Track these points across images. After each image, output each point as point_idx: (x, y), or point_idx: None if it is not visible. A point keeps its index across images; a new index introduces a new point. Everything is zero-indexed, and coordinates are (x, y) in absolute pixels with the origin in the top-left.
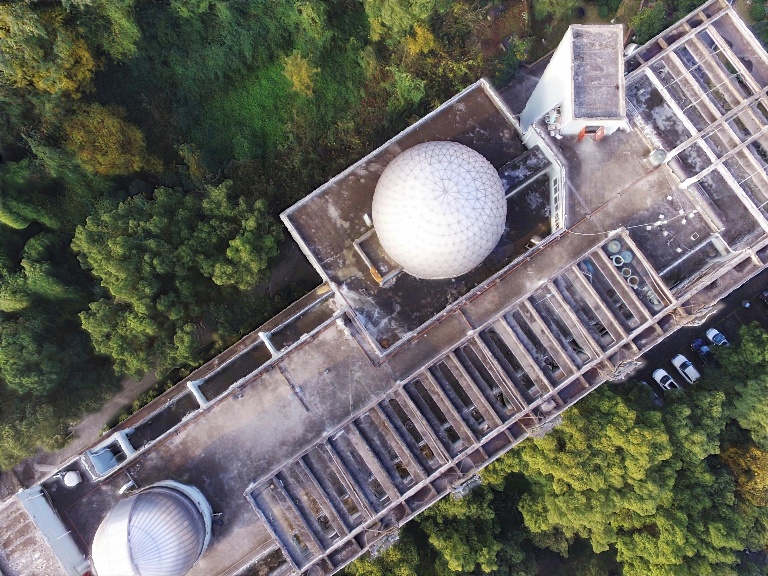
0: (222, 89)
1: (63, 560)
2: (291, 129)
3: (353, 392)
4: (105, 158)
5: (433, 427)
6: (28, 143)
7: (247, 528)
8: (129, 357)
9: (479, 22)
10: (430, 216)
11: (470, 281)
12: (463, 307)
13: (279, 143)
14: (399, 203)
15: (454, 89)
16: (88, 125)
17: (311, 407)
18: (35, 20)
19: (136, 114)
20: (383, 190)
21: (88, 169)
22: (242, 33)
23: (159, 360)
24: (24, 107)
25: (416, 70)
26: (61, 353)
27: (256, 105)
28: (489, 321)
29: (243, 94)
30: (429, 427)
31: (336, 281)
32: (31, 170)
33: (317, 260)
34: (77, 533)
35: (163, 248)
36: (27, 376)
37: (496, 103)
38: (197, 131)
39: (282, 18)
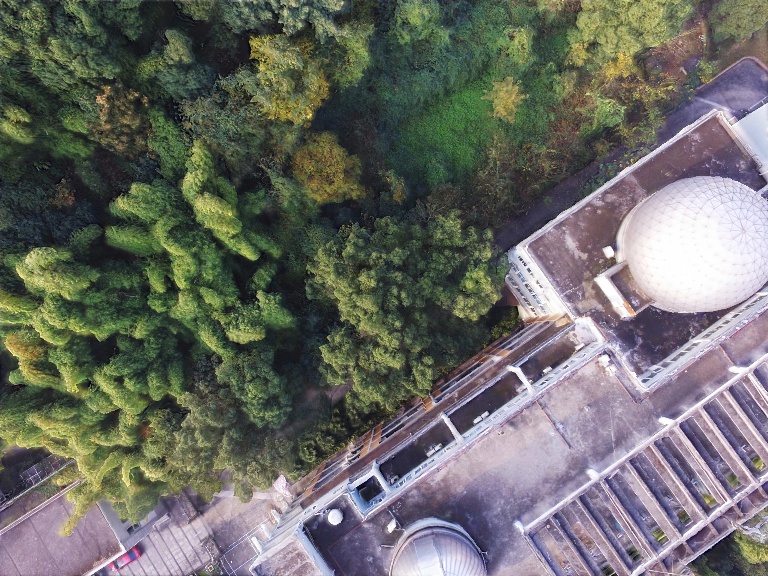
0: (418, 114)
1: None
2: (494, 155)
3: (615, 429)
4: (332, 188)
5: (709, 466)
6: (265, 174)
7: (513, 567)
8: (371, 391)
9: (677, 47)
10: (726, 256)
11: (712, 314)
12: (723, 343)
13: (480, 169)
14: (688, 241)
15: (644, 114)
16: (315, 154)
17: (573, 444)
18: (297, 53)
19: (347, 141)
20: (661, 227)
21: (316, 199)
22: (451, 59)
23: (393, 393)
24: (264, 138)
25: (613, 95)
26: (289, 385)
27: (448, 130)
28: (764, 359)
29: (436, 119)
30: (708, 466)
31: (576, 314)
32: (268, 201)
33: (557, 292)
34: (341, 572)
35: (407, 281)
36: (270, 410)
37: (732, 134)
38: (392, 156)
39: (487, 44)
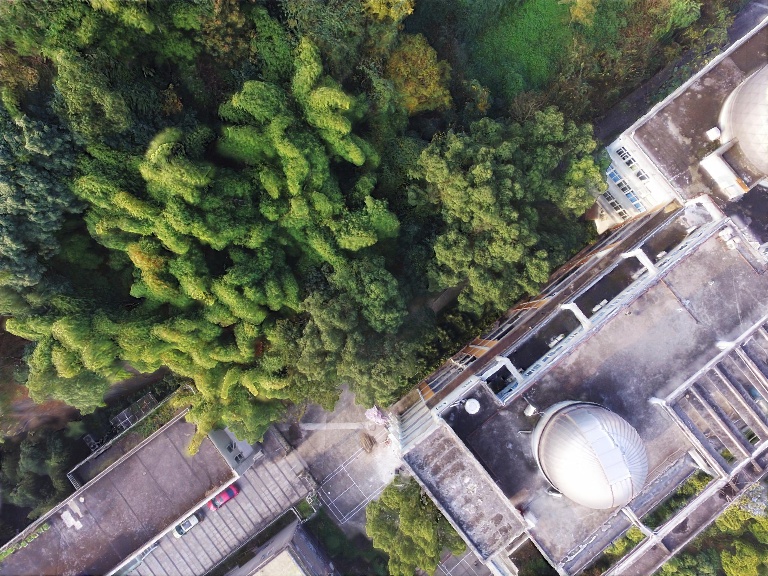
0: (495, 24)
1: (495, 483)
2: (576, 59)
3: (740, 301)
4: (429, 91)
5: None
6: (366, 76)
7: (651, 442)
8: (489, 287)
9: None
10: None
11: None
12: None
13: (562, 74)
14: None
15: (715, 14)
16: (410, 58)
17: (700, 319)
18: None
19: None
20: None
21: (414, 103)
22: None
23: (506, 291)
24: (364, 38)
25: None
26: None
27: (524, 40)
28: None
29: (512, 29)
30: None
31: (685, 198)
32: (370, 104)
33: None
34: (482, 460)
35: (518, 174)
36: (391, 312)
37: None
38: (471, 69)
39: None
